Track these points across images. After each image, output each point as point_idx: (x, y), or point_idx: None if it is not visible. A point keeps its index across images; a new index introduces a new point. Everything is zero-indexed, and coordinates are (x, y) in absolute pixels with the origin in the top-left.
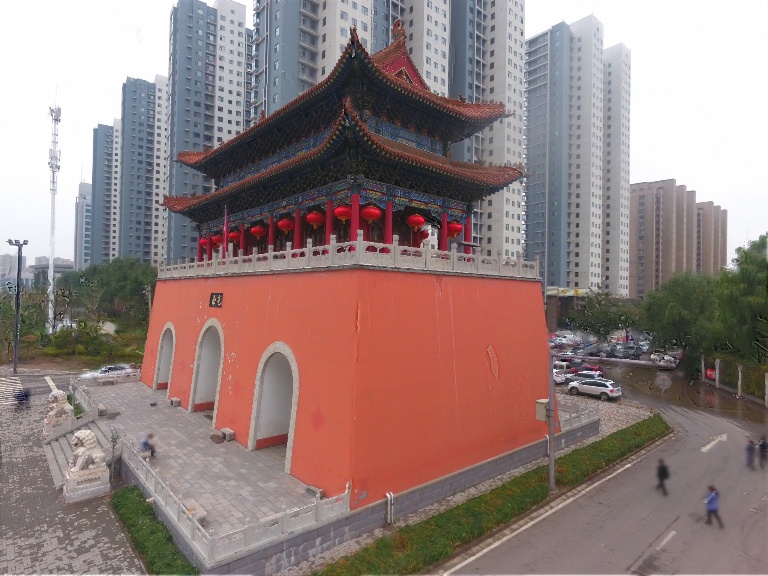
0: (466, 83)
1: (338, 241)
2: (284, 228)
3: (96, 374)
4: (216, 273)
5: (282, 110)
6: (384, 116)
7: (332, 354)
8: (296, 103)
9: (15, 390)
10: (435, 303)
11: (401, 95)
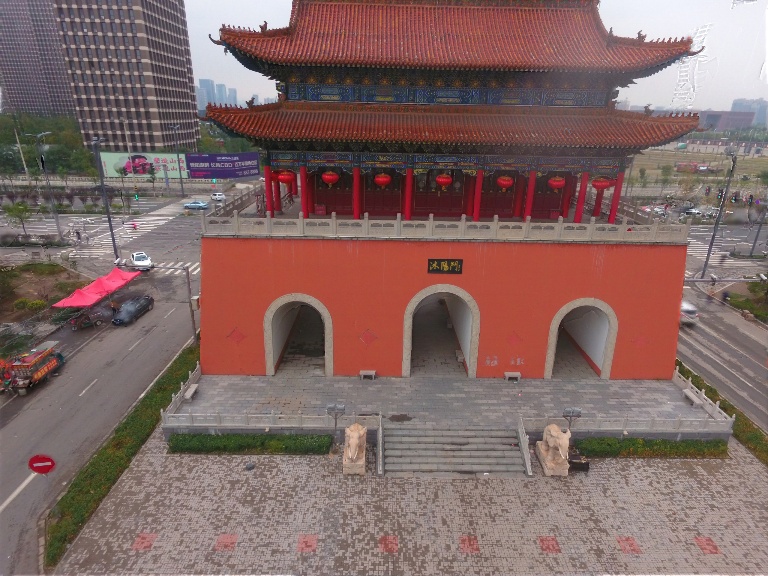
0: None
1: None
2: None
3: (701, 301)
4: None
5: None
6: None
7: None
8: None
9: None
10: None
11: None
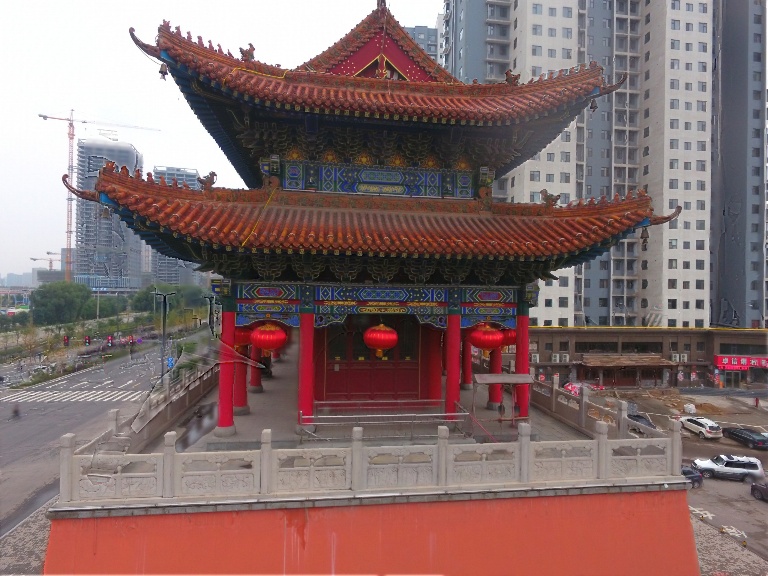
0: (749, 17)
1: None
2: None
3: None
4: None
5: None
6: (329, 153)
7: None
8: None
9: None
10: (280, 574)
11: (321, 114)
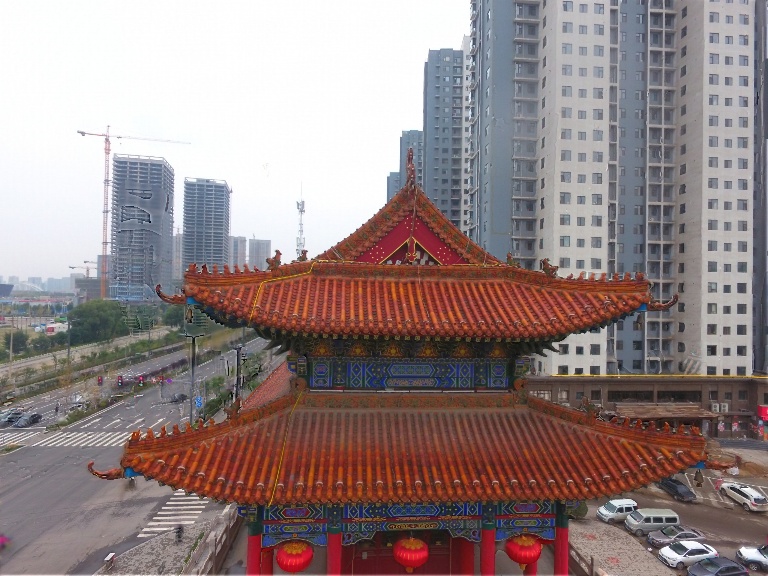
0: None
1: None
2: None
3: None
4: None
5: None
6: (357, 345)
7: None
8: None
9: None
10: None
11: None
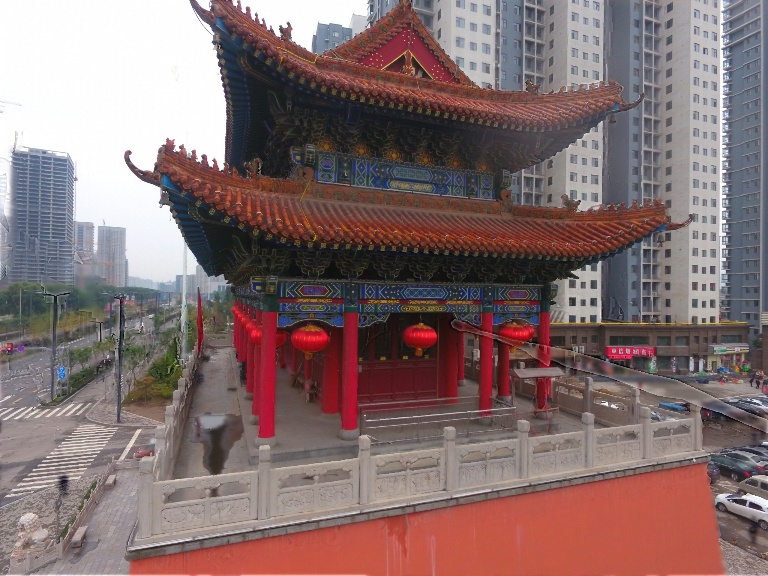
0: (630, 53)
1: None
2: None
3: None
4: None
5: (226, 154)
6: (360, 146)
7: None
8: (229, 143)
9: (92, 453)
10: None
11: (370, 106)
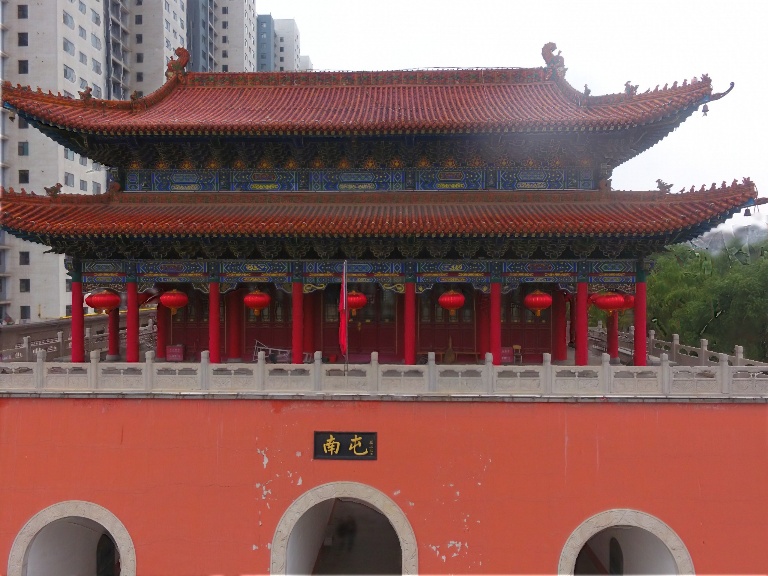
0: (200, 50)
1: (507, 322)
2: (458, 307)
3: None
4: (336, 393)
5: (495, 126)
6: None
7: (762, 514)
8: (536, 127)
9: None
10: None
11: None
